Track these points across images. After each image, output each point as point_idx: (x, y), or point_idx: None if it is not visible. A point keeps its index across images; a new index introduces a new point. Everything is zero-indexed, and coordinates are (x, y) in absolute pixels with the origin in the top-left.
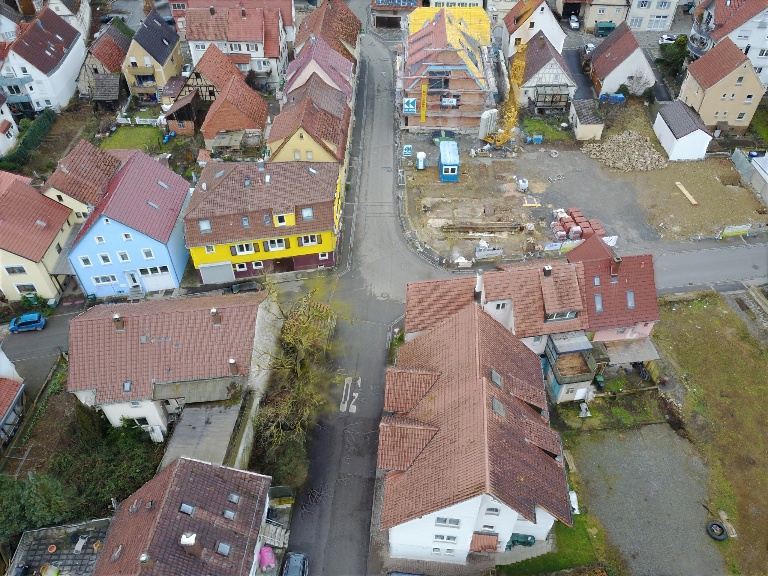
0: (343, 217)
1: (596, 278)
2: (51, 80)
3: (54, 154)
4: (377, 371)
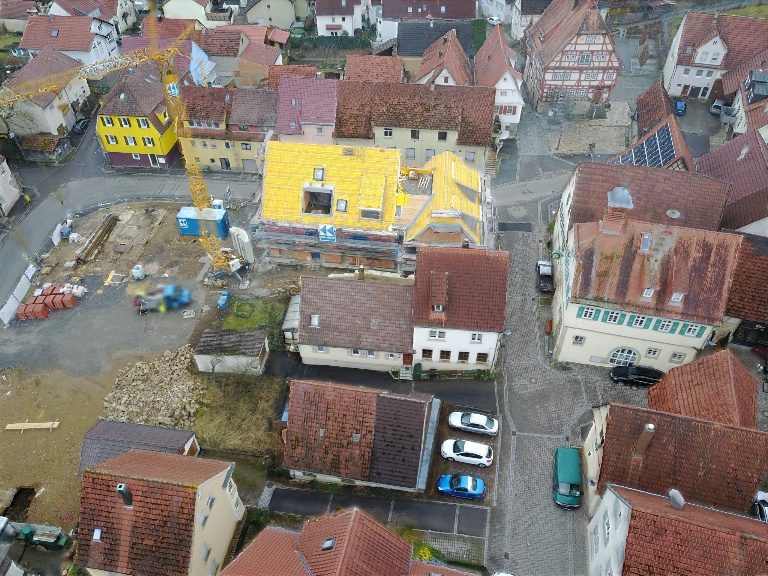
0: (169, 169)
1: None
2: (384, 24)
3: (300, 50)
4: None
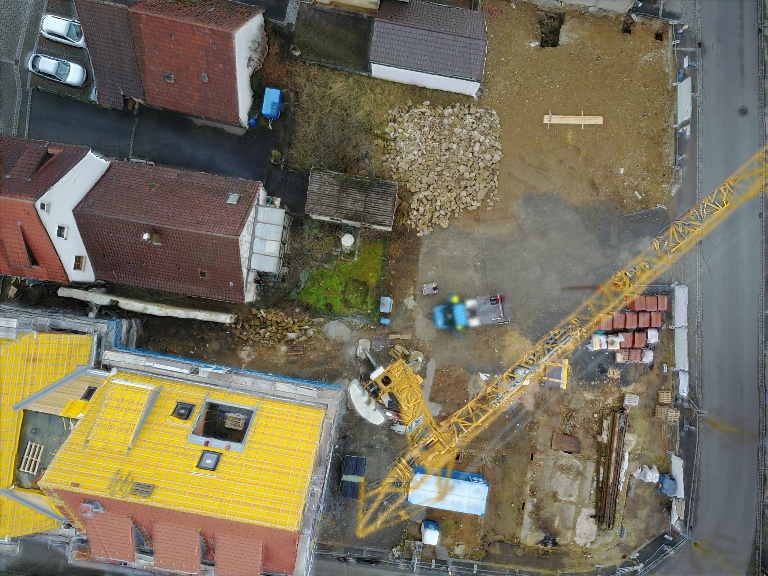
0: None
1: None
2: None
3: None
4: None
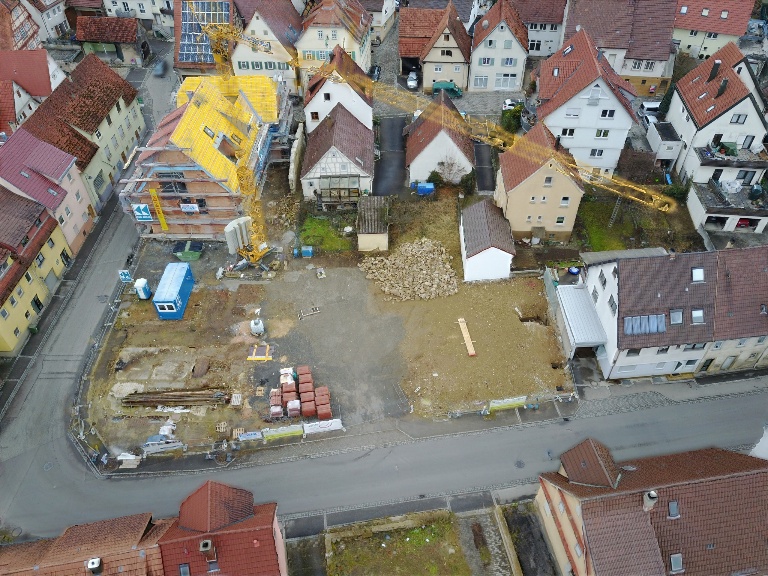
0: (5, 381)
1: (183, 567)
2: None
3: None
4: None
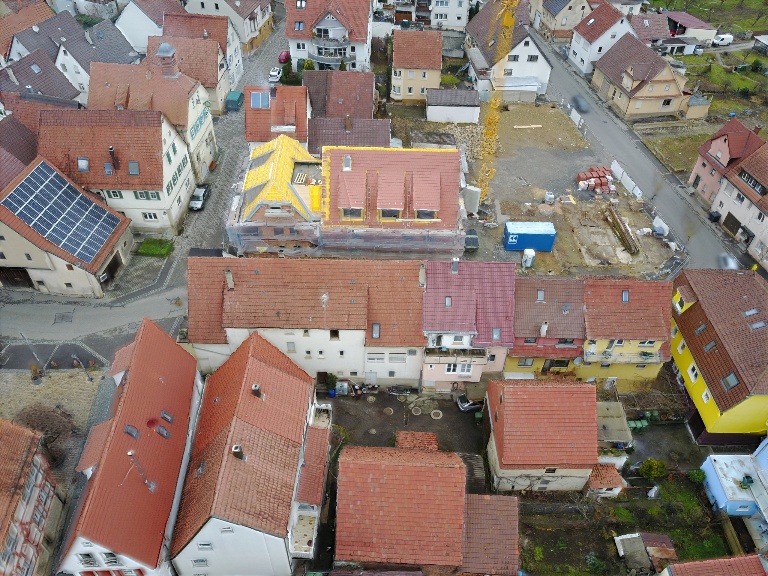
0: None
1: None
2: None
3: None
4: None
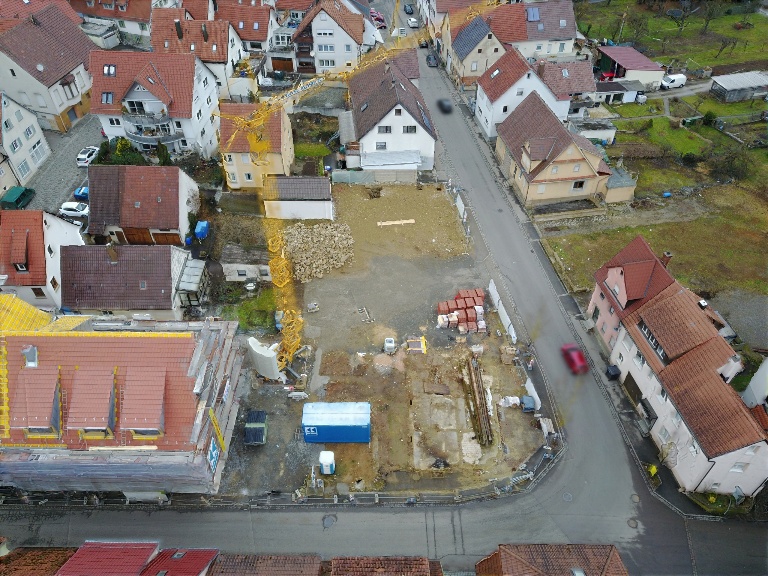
0: None
1: None
2: None
3: None
4: (763, 532)
